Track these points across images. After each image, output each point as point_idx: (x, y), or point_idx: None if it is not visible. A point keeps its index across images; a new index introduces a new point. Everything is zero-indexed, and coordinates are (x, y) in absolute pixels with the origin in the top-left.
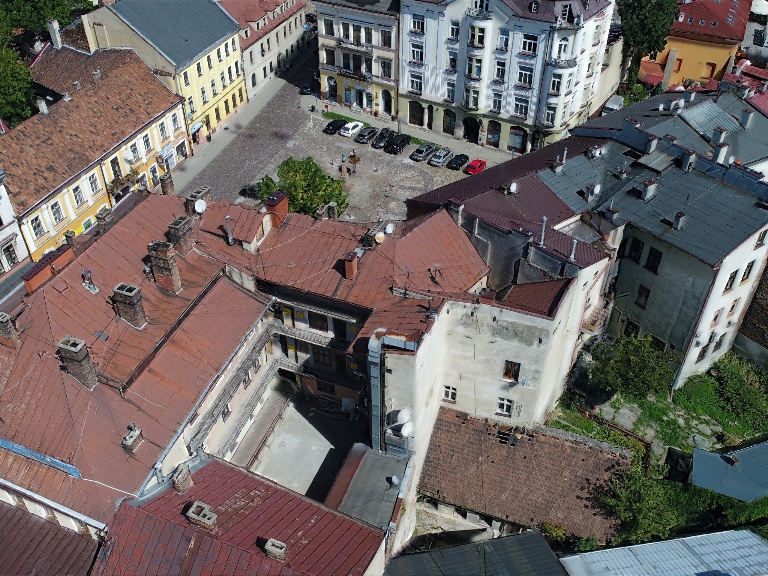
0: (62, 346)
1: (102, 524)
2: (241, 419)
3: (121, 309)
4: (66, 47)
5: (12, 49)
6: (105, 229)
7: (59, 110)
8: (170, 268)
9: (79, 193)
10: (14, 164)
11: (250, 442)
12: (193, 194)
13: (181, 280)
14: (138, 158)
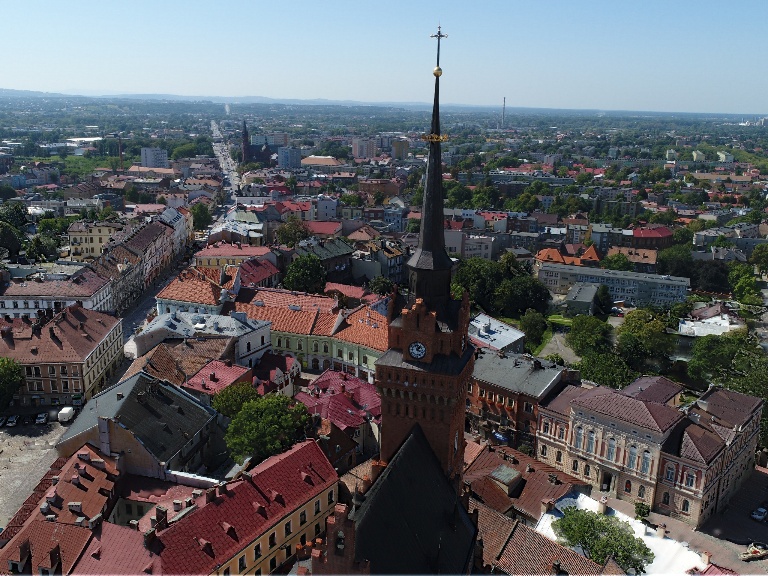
0: None
1: None
2: None
3: None
4: None
5: None
6: None
7: None
8: None
9: None
10: None
11: None
12: (38, 324)
13: None
14: None
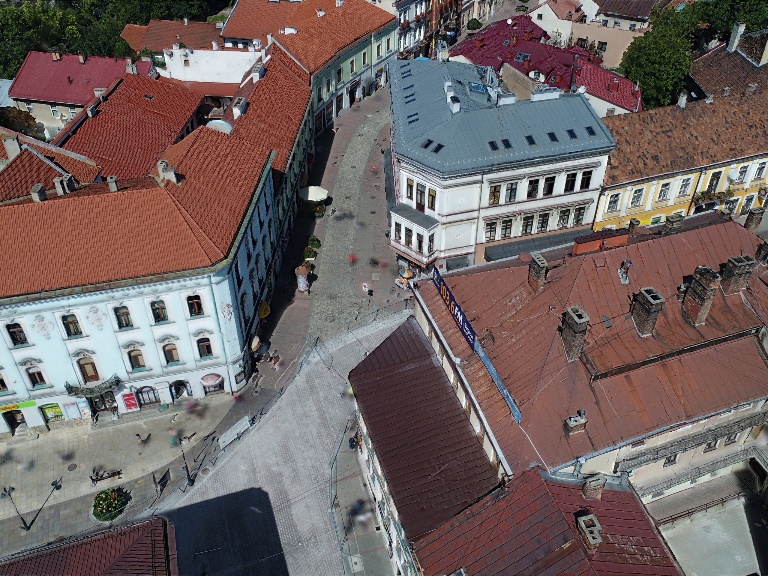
0: (570, 311)
1: (511, 471)
2: (681, 476)
3: (637, 309)
4: (738, 52)
5: (688, 40)
6: (668, 232)
7: (695, 108)
8: (705, 298)
9: (666, 189)
10: (628, 141)
11: (676, 502)
12: None
13: (708, 315)
14: (742, 181)
